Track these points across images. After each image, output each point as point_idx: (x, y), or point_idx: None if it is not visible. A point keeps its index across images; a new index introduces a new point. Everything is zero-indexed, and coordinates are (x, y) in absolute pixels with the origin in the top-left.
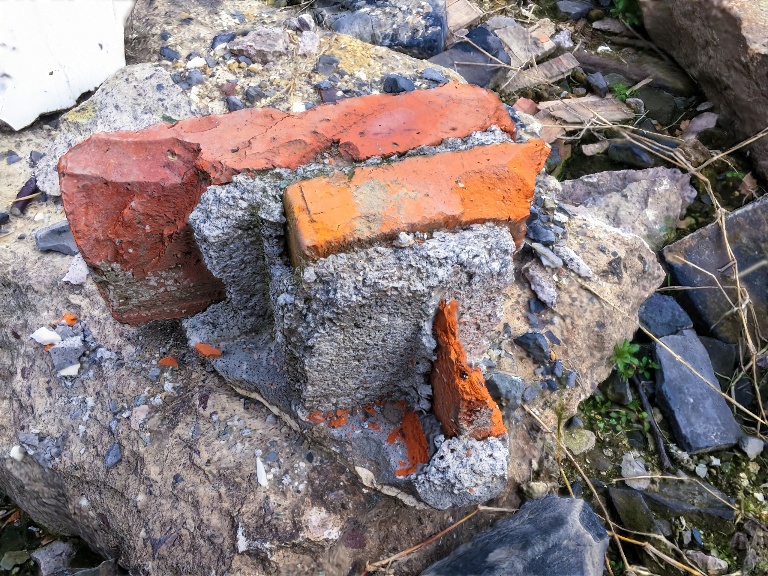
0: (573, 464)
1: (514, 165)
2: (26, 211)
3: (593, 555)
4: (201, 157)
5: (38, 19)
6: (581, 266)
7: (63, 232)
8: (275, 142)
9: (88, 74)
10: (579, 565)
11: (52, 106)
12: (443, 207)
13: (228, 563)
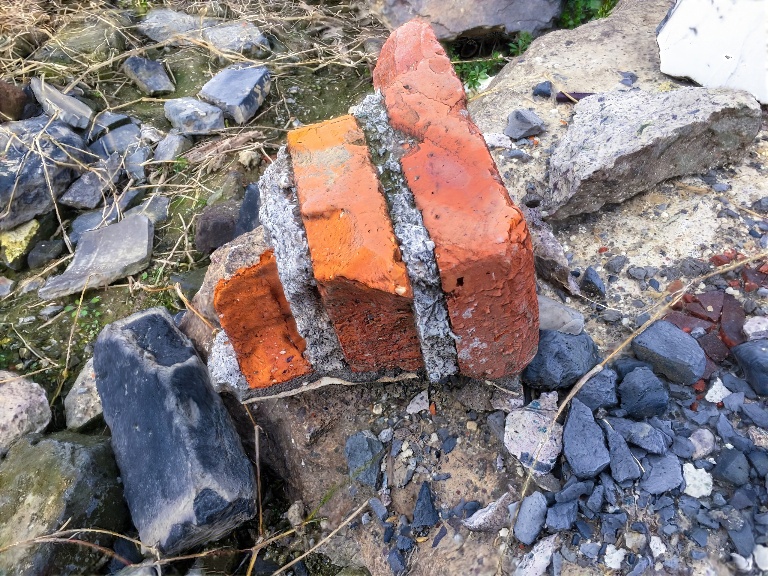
0: (326, 572)
1: (362, 252)
2: (561, 104)
3: (188, 505)
4: (401, 74)
5: (764, 11)
6: (525, 570)
7: (517, 118)
8: (416, 105)
9: (757, 84)
10: (182, 488)
11: (701, 79)
12: (312, 201)
13: (229, 246)
